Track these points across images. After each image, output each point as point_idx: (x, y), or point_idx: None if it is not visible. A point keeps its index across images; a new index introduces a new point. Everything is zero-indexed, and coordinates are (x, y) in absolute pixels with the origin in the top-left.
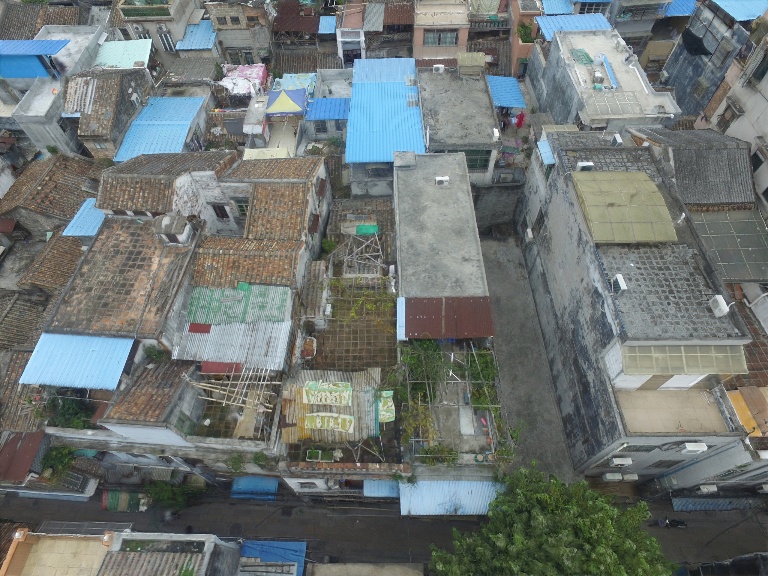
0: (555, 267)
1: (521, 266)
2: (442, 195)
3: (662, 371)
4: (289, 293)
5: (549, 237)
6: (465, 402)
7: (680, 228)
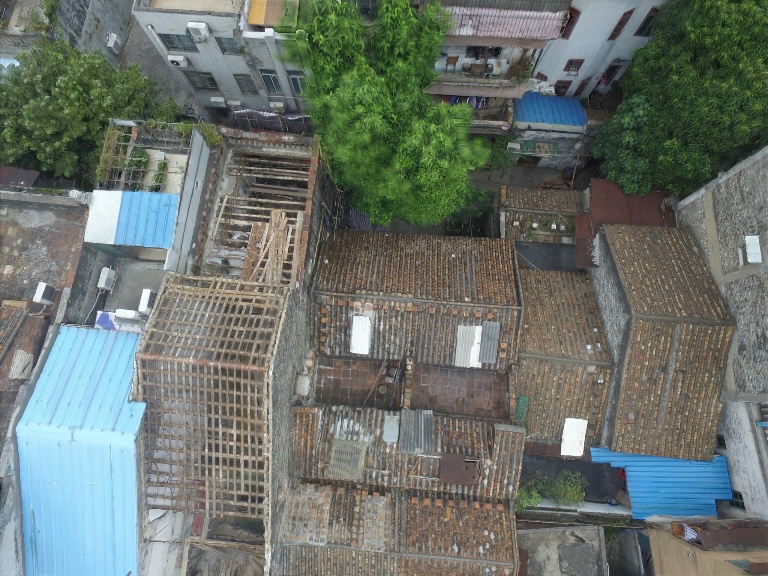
0: None
1: None
2: None
3: None
4: None
5: None
6: None
7: None
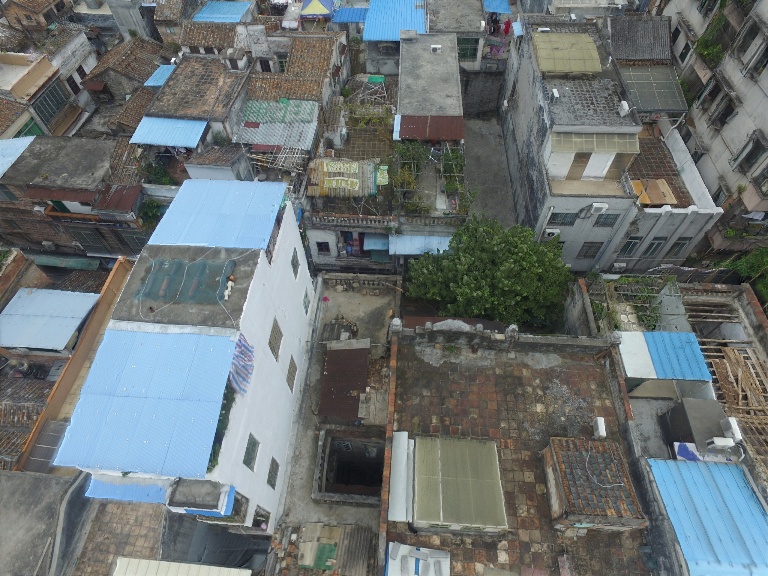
0: (520, 116)
1: (499, 137)
2: (435, 59)
3: (578, 150)
4: (317, 105)
5: (518, 97)
6: (441, 190)
7: (608, 70)
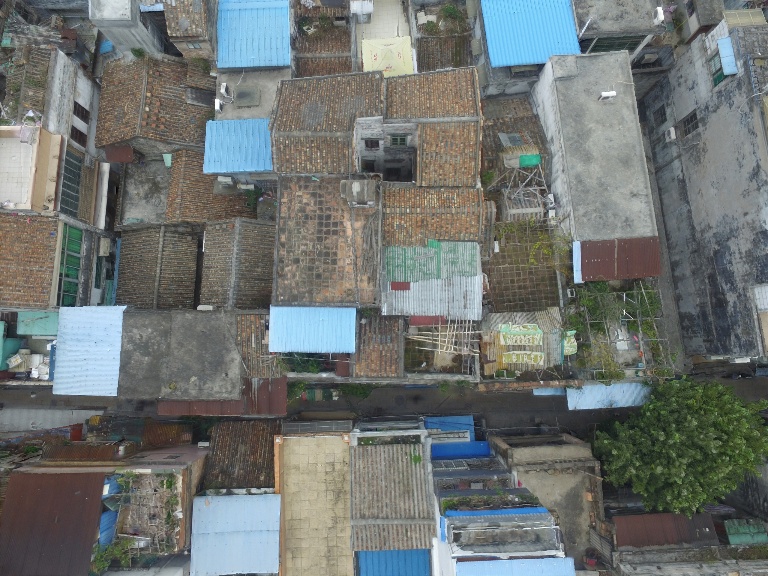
0: (704, 182)
1: (648, 159)
2: (606, 114)
3: None
4: (478, 249)
5: (702, 148)
6: None
7: None
